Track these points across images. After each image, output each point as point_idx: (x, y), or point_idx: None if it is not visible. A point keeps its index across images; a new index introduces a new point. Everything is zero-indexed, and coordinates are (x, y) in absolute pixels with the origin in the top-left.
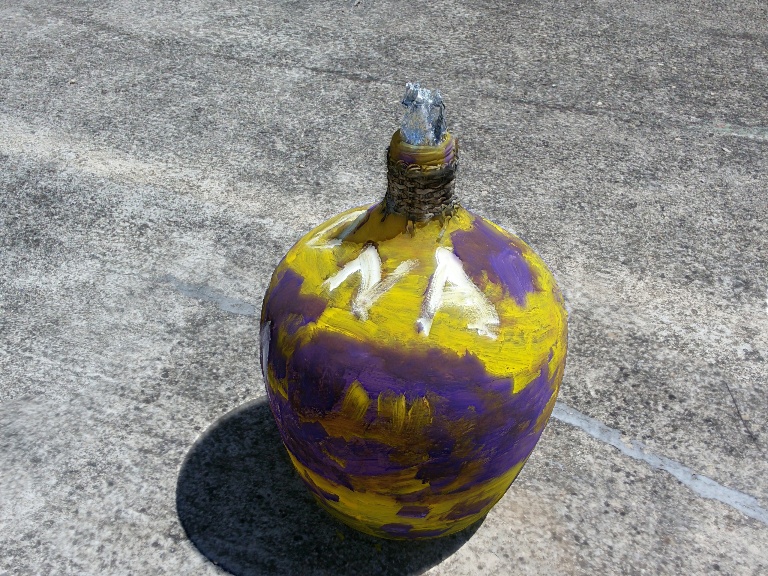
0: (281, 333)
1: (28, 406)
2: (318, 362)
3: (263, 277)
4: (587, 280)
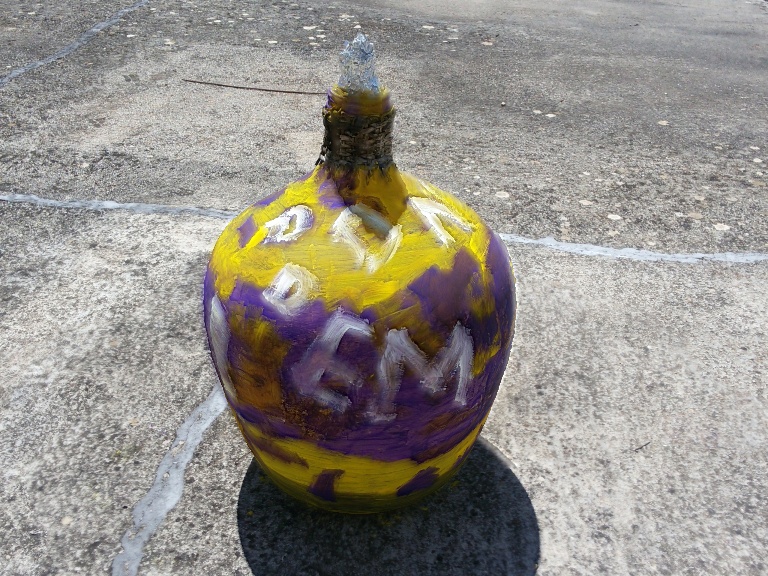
0: (478, 306)
1: None
2: (505, 278)
3: None
4: (4, 362)
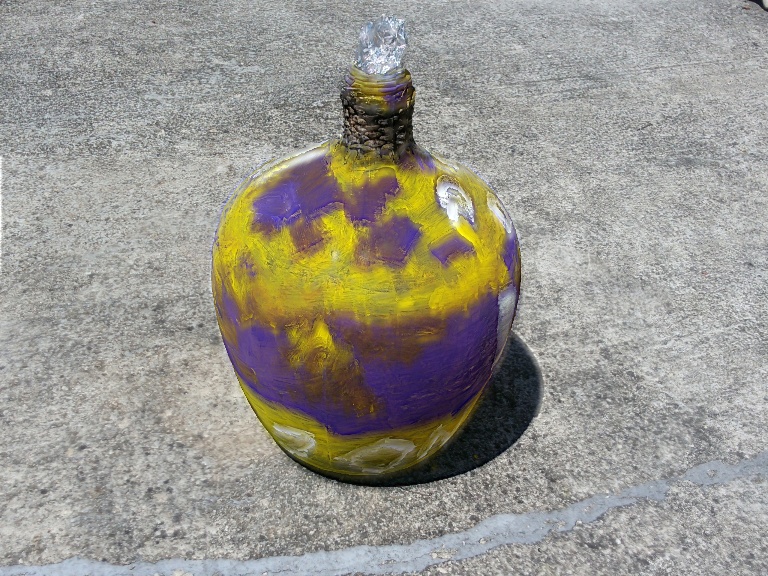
0: None
1: (657, 302)
2: None
3: (763, 532)
4: None
